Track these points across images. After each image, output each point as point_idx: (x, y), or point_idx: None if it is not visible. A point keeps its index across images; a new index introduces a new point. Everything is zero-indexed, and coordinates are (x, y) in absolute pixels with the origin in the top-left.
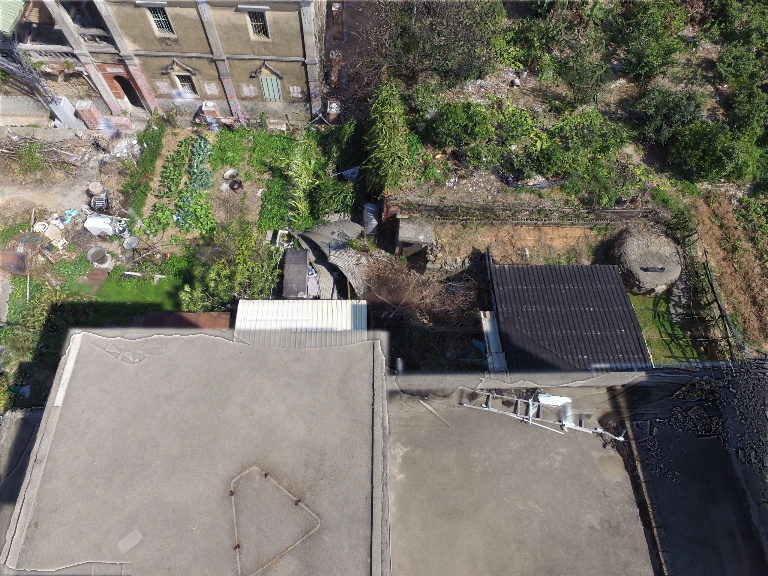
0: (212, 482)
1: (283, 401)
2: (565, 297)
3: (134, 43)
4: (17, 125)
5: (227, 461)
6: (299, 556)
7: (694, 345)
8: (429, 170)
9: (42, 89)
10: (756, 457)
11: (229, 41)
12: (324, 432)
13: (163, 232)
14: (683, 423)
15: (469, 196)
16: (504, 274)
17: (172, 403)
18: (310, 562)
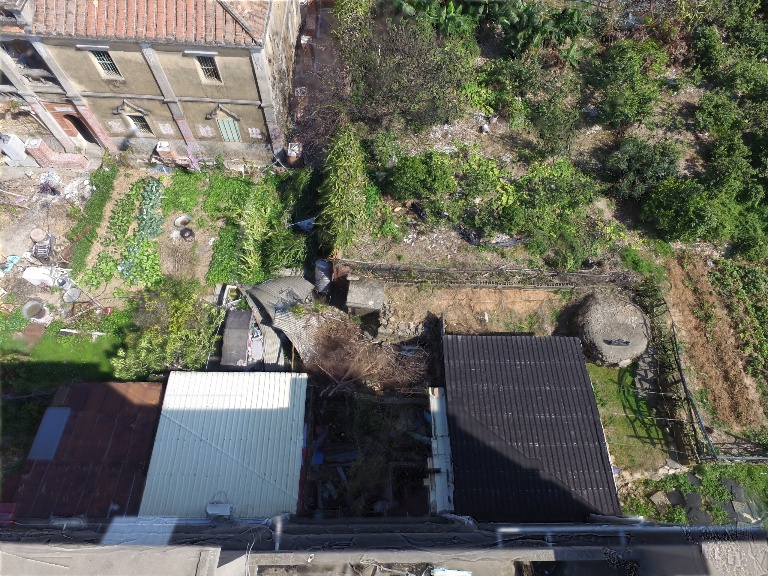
0: None
1: None
2: (520, 374)
3: (80, 84)
4: None
5: None
6: None
7: (659, 424)
8: (386, 225)
9: None
10: (720, 553)
11: (180, 84)
12: None
13: (106, 284)
14: (645, 509)
15: (427, 254)
16: (456, 346)
17: None
18: None
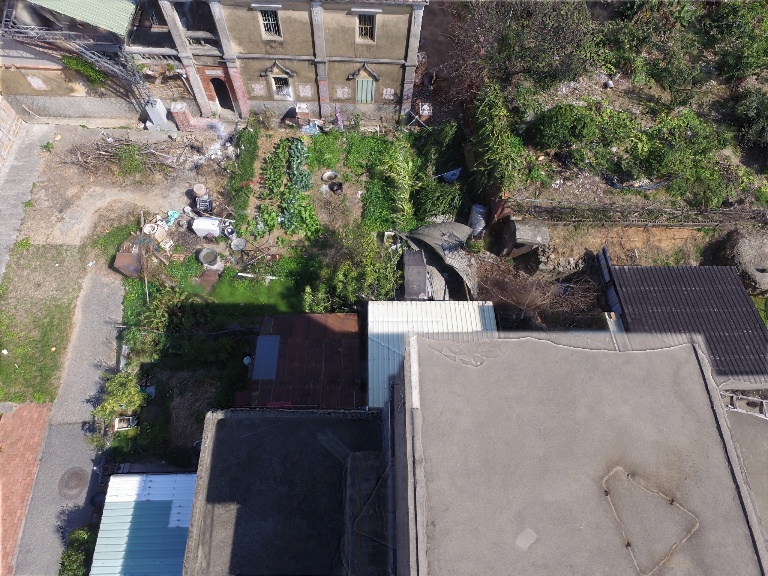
0: (583, 482)
1: (623, 403)
2: (688, 298)
3: (239, 46)
4: (107, 127)
5: (594, 462)
6: (684, 554)
7: None
8: (534, 172)
9: (137, 91)
10: None
11: (334, 44)
12: (673, 433)
13: (269, 234)
14: None
15: (576, 198)
16: (625, 275)
17: (512, 405)
18: (698, 560)
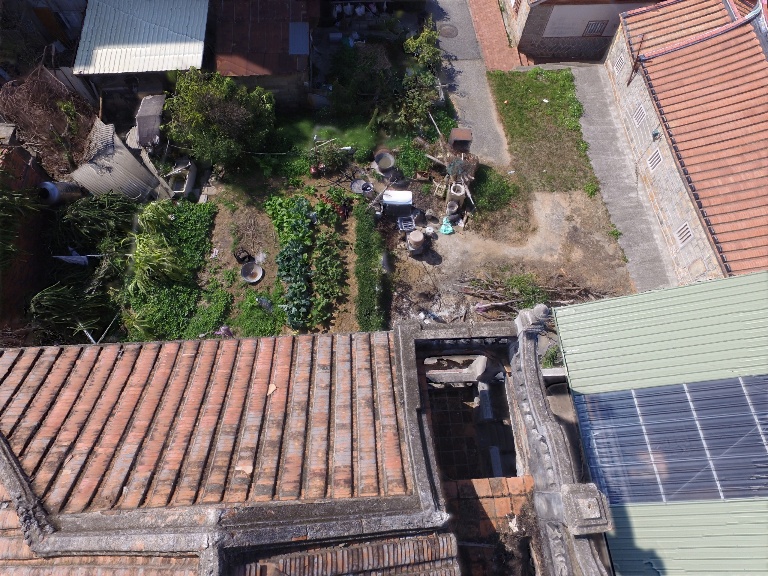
0: None
1: None
2: None
3: None
4: None
5: None
6: None
7: None
8: None
9: None
10: None
11: None
12: None
13: None
14: None
15: None
16: None
17: None
18: None
